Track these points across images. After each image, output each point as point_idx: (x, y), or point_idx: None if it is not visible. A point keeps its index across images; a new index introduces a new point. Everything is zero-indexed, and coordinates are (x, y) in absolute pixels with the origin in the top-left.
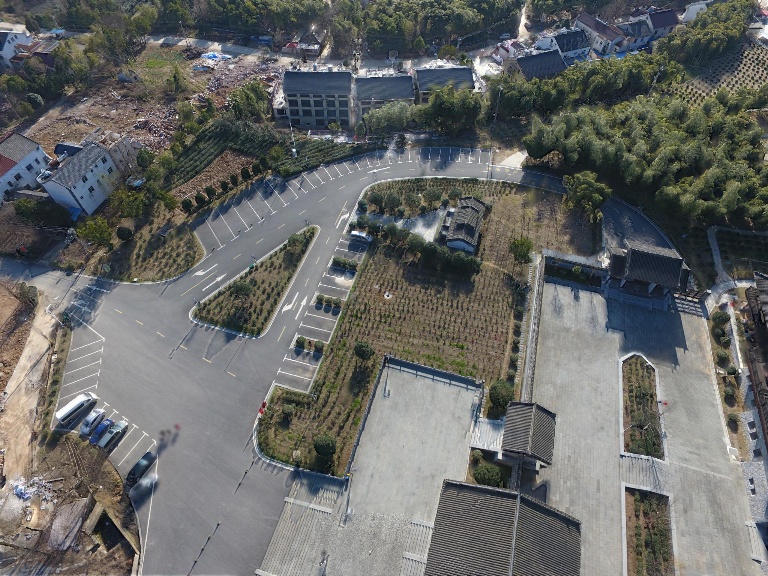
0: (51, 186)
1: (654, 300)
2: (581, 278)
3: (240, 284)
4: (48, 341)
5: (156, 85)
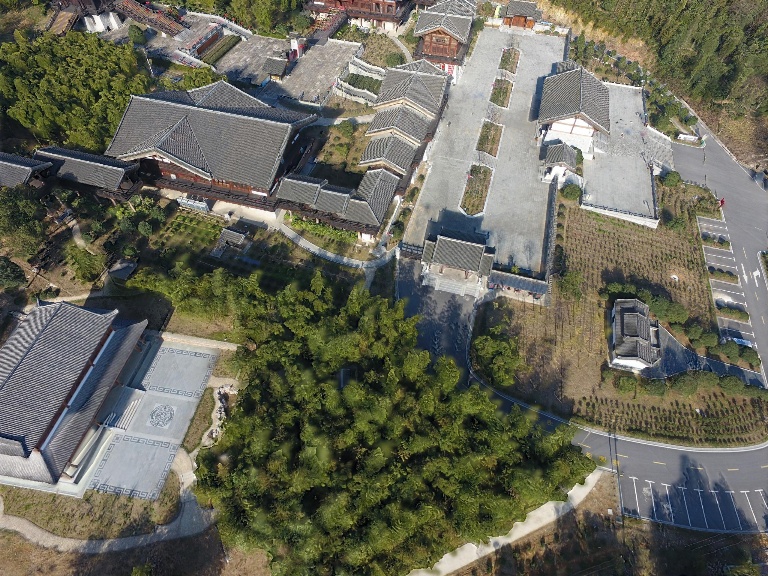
0: None
1: None
2: (508, 268)
3: None
4: None
5: None
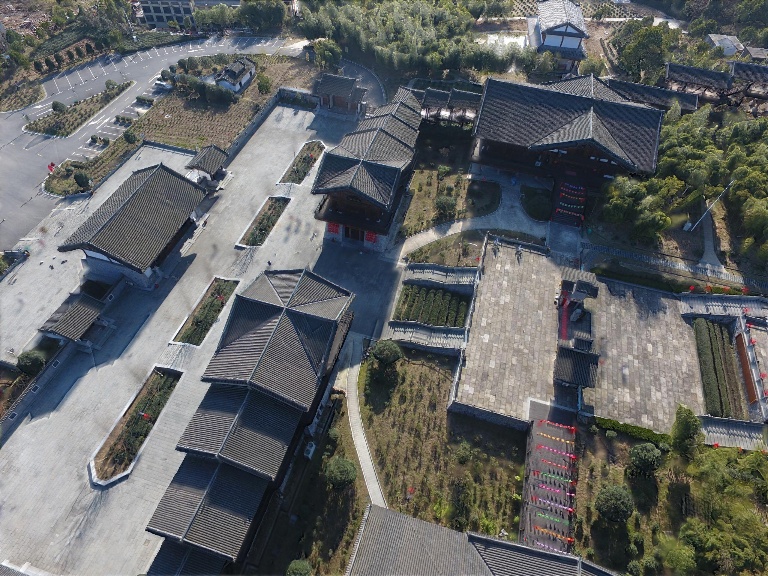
0: None
1: (349, 115)
2: (301, 102)
3: (55, 102)
4: None
5: (49, 3)
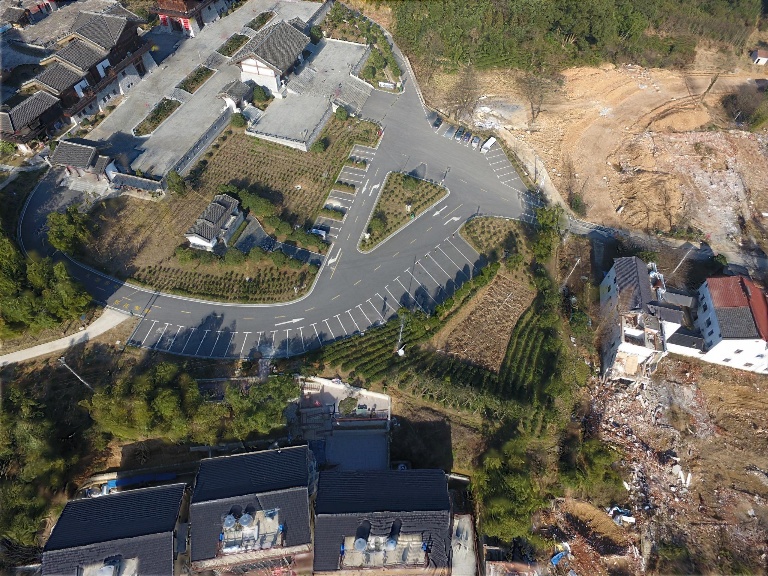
0: None
1: None
2: None
3: (411, 178)
4: None
5: None
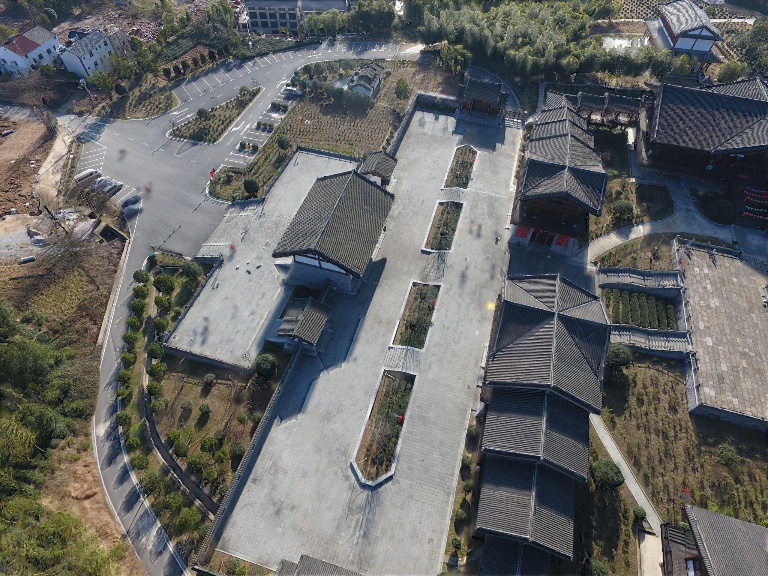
0: (66, 56)
1: (490, 120)
2: (441, 107)
3: (202, 109)
4: (66, 150)
5: (146, 9)
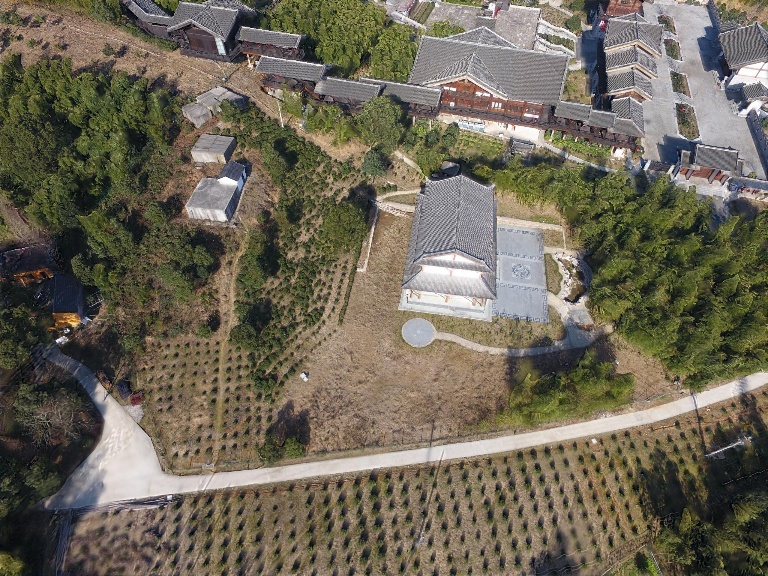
0: None
1: None
2: None
3: None
4: None
5: None
